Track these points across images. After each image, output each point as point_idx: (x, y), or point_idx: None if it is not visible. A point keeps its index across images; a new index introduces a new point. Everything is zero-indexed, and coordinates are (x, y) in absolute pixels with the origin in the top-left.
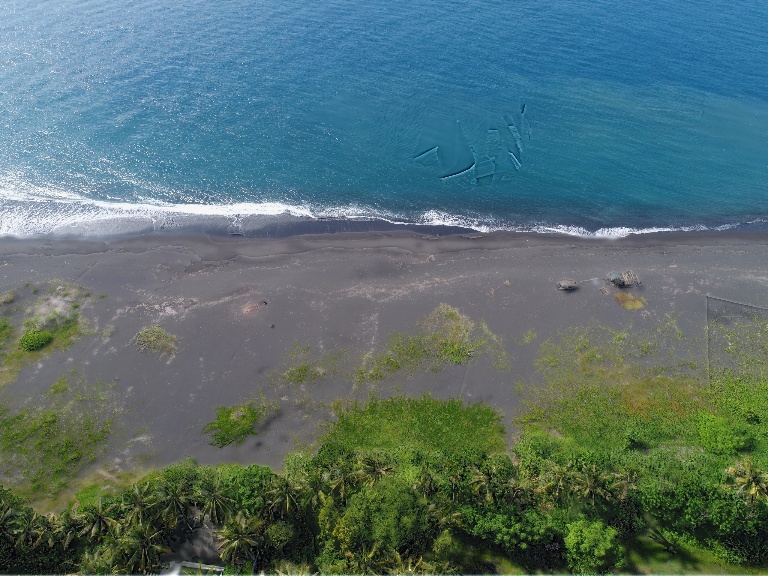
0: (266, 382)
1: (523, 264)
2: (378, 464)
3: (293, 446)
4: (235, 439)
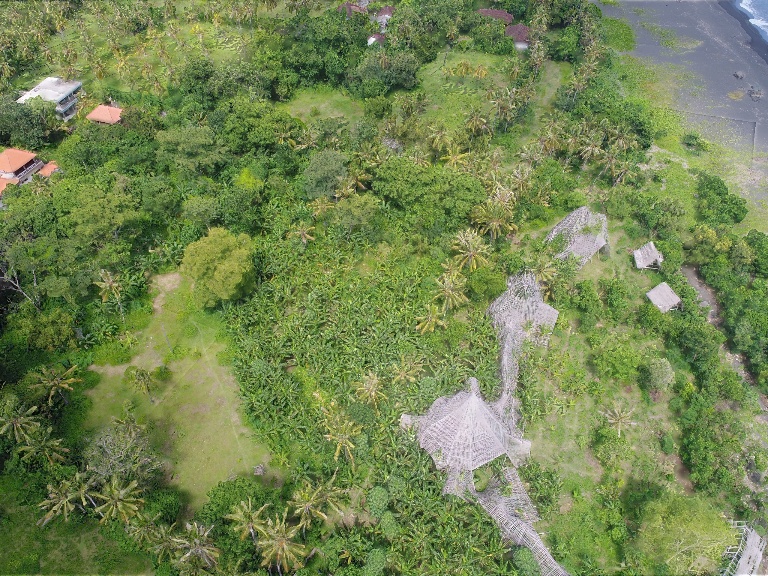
0: (631, 5)
1: (756, 70)
2: None
3: None
4: (600, 2)
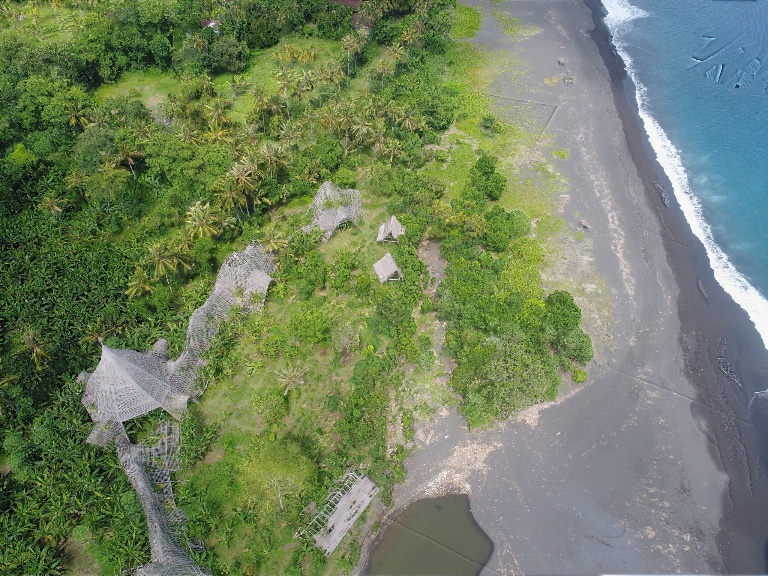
0: None
1: (584, 57)
2: (445, 8)
3: (459, 1)
4: None
